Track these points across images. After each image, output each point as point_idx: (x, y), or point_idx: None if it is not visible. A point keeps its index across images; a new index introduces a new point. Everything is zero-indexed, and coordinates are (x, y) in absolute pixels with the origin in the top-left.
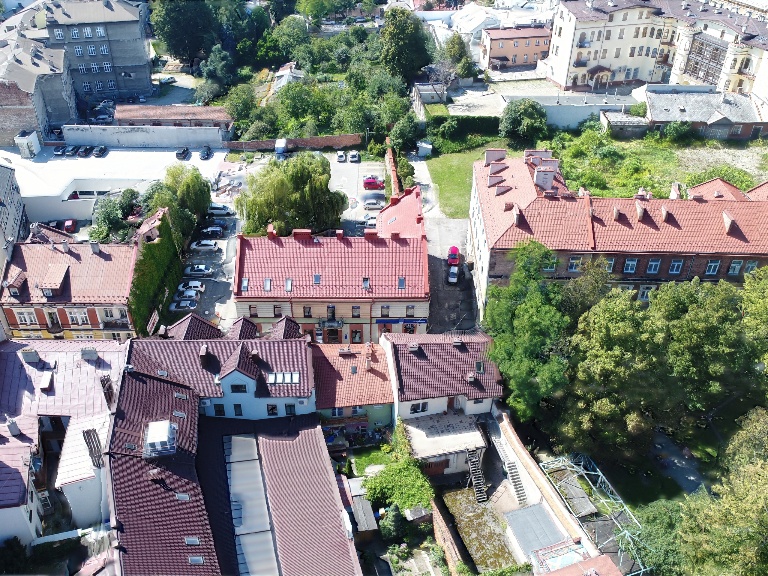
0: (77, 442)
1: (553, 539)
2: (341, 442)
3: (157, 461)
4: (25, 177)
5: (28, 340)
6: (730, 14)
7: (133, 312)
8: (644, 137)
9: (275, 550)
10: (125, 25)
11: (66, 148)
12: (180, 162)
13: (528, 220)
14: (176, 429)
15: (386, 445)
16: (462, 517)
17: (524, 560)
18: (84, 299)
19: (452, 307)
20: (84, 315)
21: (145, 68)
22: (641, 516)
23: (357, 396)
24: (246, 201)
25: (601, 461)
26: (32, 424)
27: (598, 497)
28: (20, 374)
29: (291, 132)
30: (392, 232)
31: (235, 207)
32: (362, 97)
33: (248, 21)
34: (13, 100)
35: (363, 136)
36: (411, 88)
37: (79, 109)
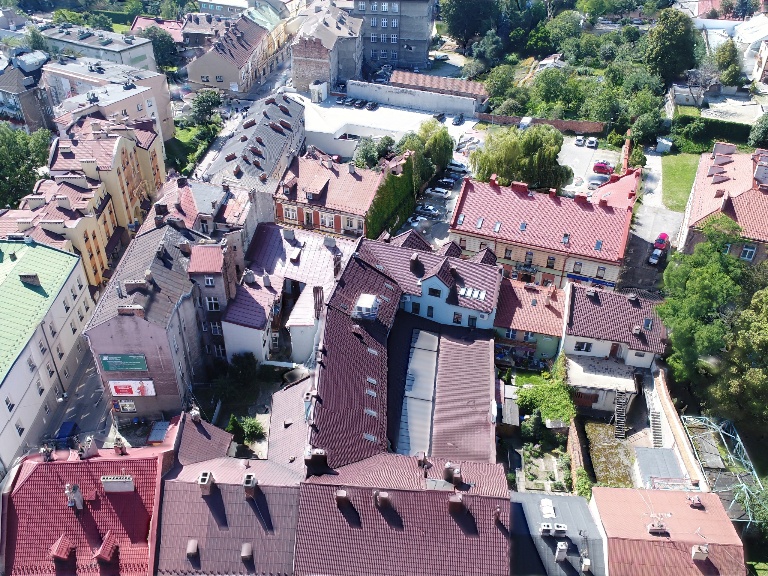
0: (307, 301)
1: (674, 477)
2: (508, 359)
3: (360, 323)
4: (311, 114)
5: (289, 226)
6: None
7: (368, 225)
8: None
9: (432, 415)
10: (417, 3)
11: (346, 99)
12: (434, 119)
13: (735, 208)
14: (379, 304)
15: (547, 372)
16: (597, 443)
17: (641, 485)
18: (335, 206)
19: (645, 283)
20: (332, 220)
21: (425, 43)
22: (767, 483)
23: (531, 324)
24: (480, 156)
25: (745, 432)
26: (279, 282)
27: (733, 464)
28: (279, 246)
29: (538, 112)
30: (601, 199)
31: (470, 160)
32: (616, 92)
33: (526, 12)
34: (316, 54)
35: (606, 125)
36: (668, 89)
37: (363, 71)
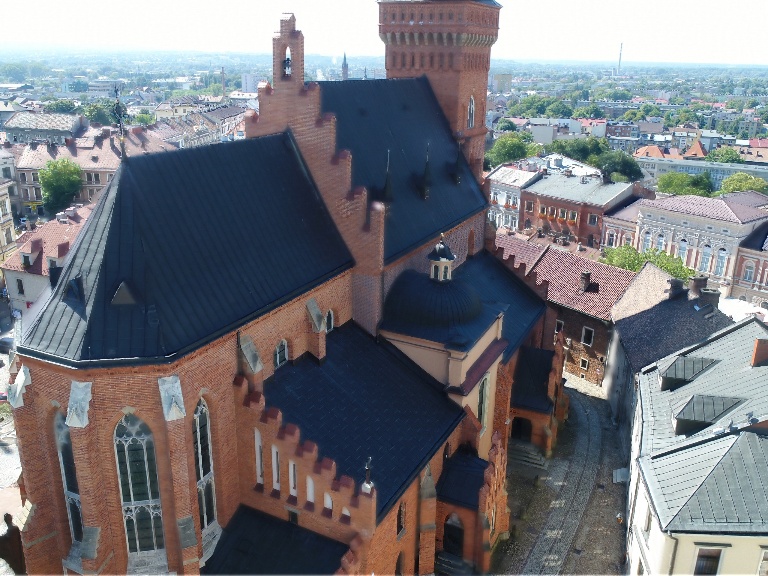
0: None
1: None
2: None
3: None
4: None
5: None
6: (205, 106)
7: None
8: None
9: None
10: (9, 113)
11: None
12: None
13: None
14: None
15: None
16: None
17: None
18: None
19: None
20: None
21: None
22: None
23: None
24: None
25: None
26: None
27: None
28: None
29: None
30: None
31: None
32: None
33: None
34: None
35: None
36: None
37: None
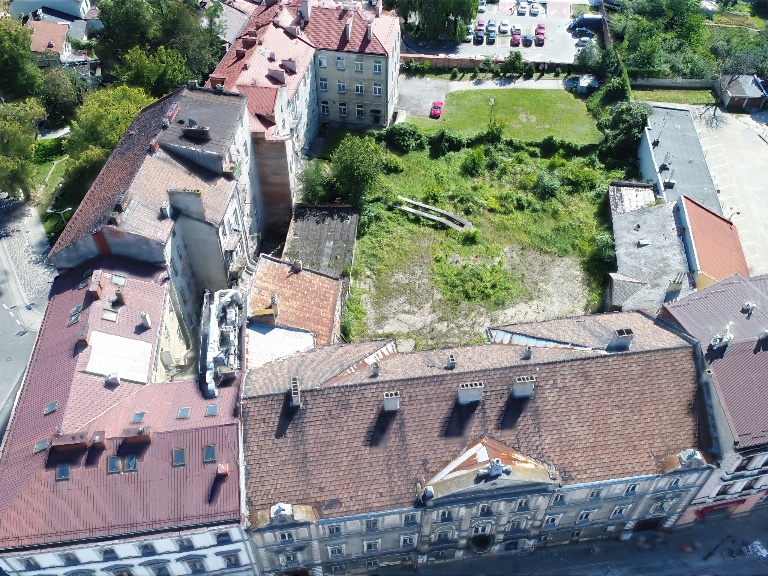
0: None
1: None
2: None
3: None
4: None
5: None
6: None
7: None
8: (600, 227)
9: None
10: None
11: None
12: None
13: None
14: None
15: None
16: None
17: None
18: None
19: None
20: None
21: None
22: None
23: None
24: None
25: None
26: None
27: None
28: None
29: None
30: None
31: None
32: None
33: None
34: None
35: None
36: None
37: None
